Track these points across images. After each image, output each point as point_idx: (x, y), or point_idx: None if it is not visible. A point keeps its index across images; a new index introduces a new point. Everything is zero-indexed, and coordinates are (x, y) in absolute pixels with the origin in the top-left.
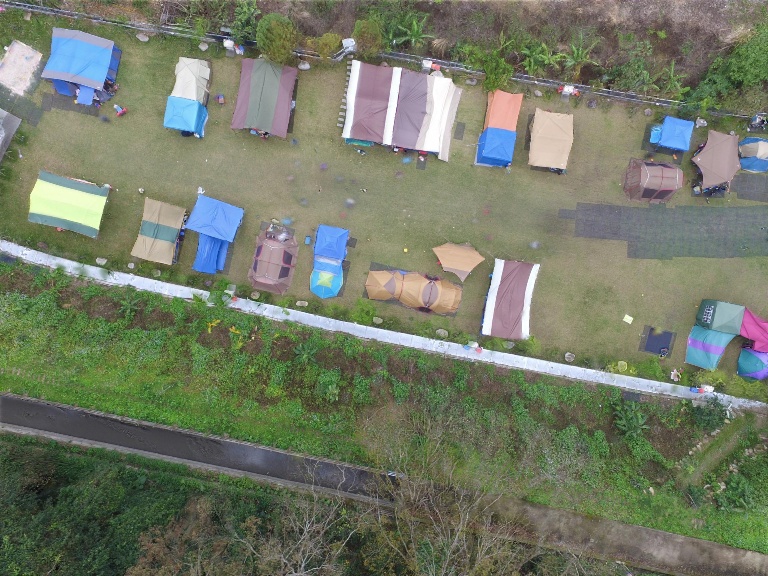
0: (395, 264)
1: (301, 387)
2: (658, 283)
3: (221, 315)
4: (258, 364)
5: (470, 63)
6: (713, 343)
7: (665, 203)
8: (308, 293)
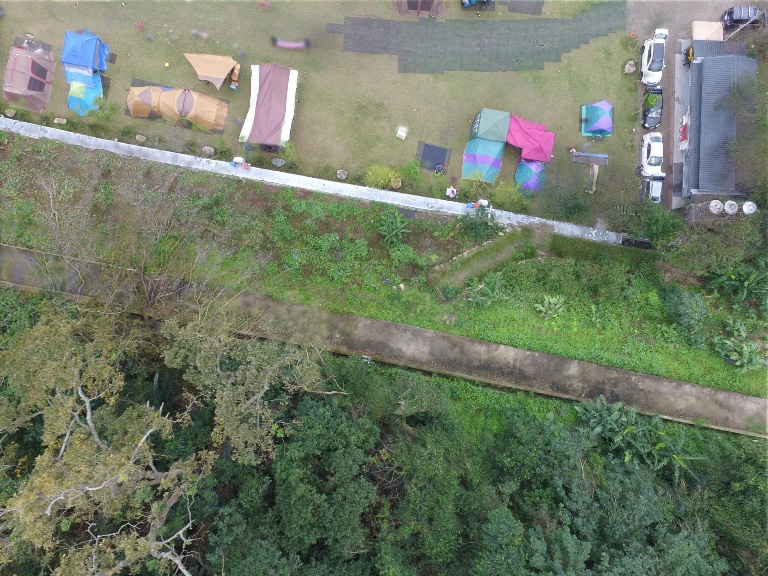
0: (158, 80)
1: (39, 189)
2: (430, 98)
3: None
4: None
5: None
6: (483, 153)
7: (435, 17)
8: (67, 111)
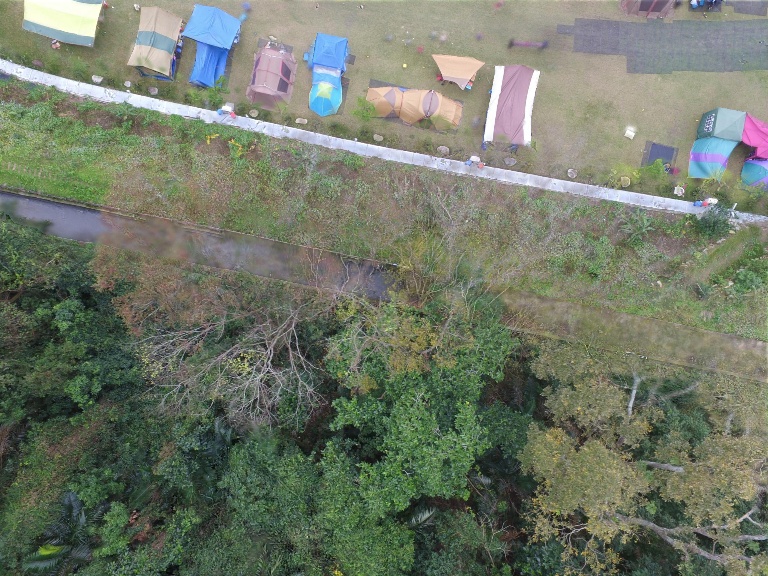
0: (394, 81)
1: (302, 188)
2: (658, 98)
3: (220, 130)
4: (258, 168)
5: None
6: (715, 152)
7: (663, 18)
8: (307, 111)
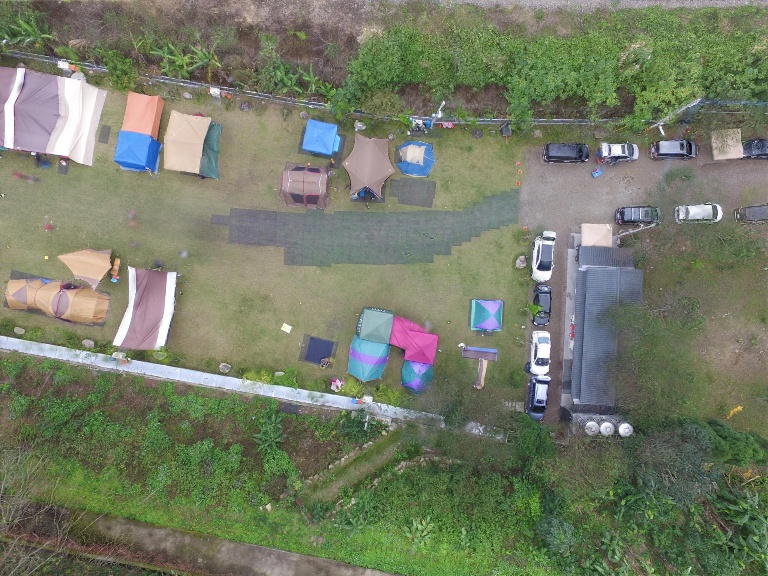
0: (37, 272)
1: None
2: (317, 291)
3: None
4: None
5: None
6: (366, 352)
7: (323, 208)
8: None
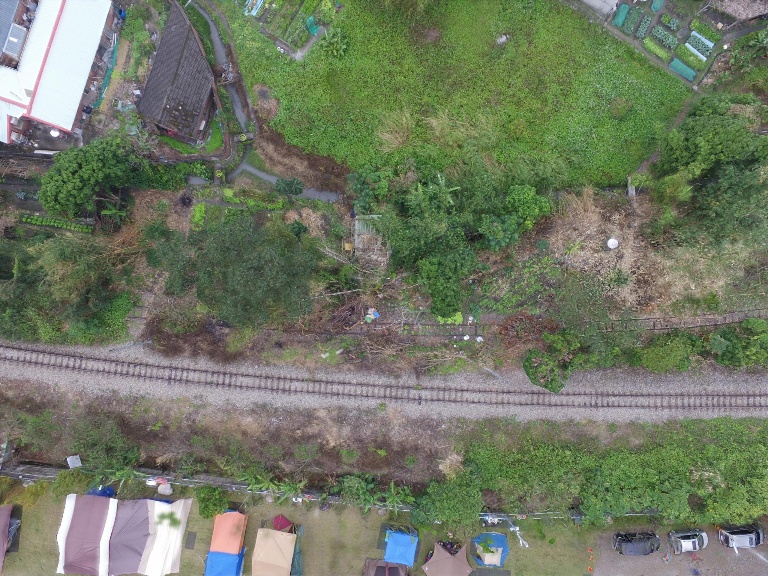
0: None
1: None
2: None
3: None
4: None
5: (203, 466)
6: None
7: None
8: None
